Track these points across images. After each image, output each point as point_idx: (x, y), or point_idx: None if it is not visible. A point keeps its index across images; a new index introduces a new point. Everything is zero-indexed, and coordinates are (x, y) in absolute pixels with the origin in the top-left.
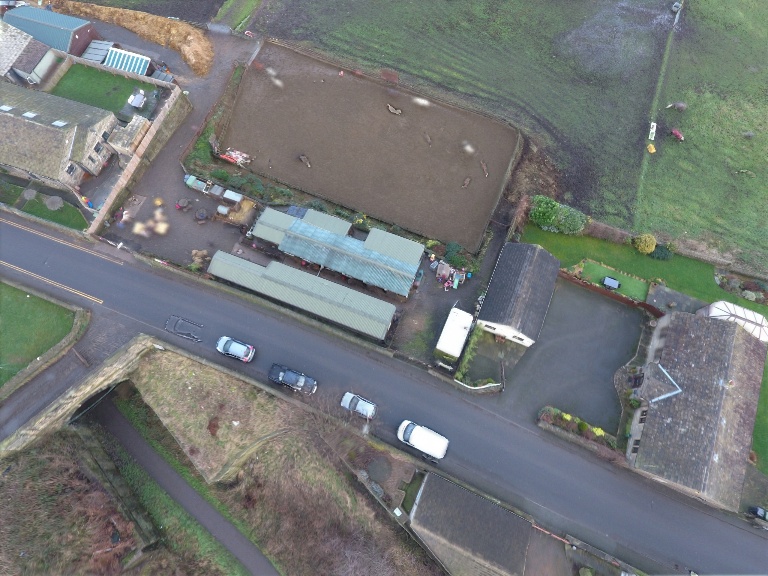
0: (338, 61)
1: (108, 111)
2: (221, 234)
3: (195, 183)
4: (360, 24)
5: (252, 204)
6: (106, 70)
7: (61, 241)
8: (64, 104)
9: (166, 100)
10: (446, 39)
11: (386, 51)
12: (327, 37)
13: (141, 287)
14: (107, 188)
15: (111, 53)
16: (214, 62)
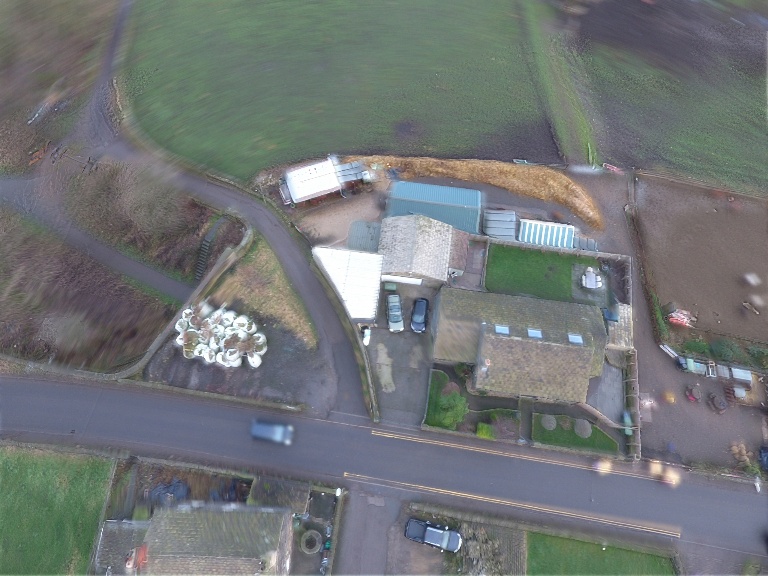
0: (728, 187)
1: (594, 306)
2: (743, 420)
3: (694, 367)
4: (679, 129)
5: (754, 377)
6: (530, 247)
7: (593, 469)
8: (545, 307)
9: (627, 276)
10: (762, 131)
11: (725, 157)
12: (663, 151)
13: (711, 507)
14: (607, 392)
15: (524, 226)
16: (597, 208)
